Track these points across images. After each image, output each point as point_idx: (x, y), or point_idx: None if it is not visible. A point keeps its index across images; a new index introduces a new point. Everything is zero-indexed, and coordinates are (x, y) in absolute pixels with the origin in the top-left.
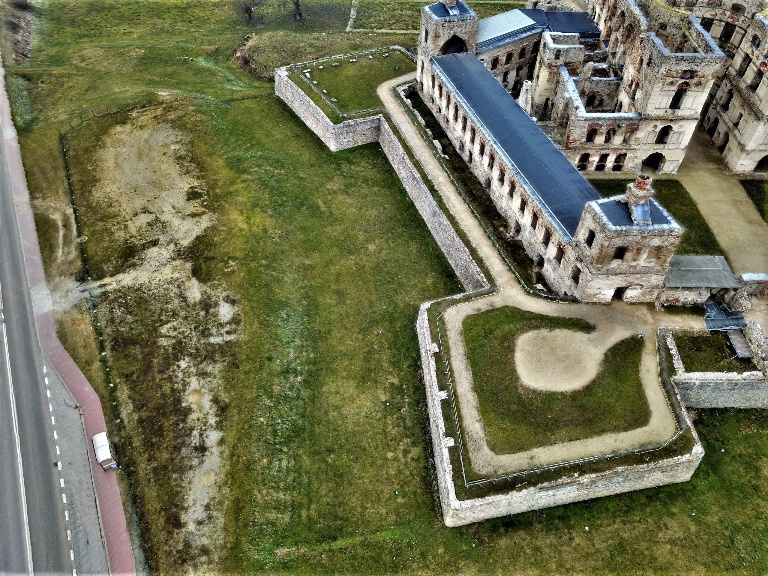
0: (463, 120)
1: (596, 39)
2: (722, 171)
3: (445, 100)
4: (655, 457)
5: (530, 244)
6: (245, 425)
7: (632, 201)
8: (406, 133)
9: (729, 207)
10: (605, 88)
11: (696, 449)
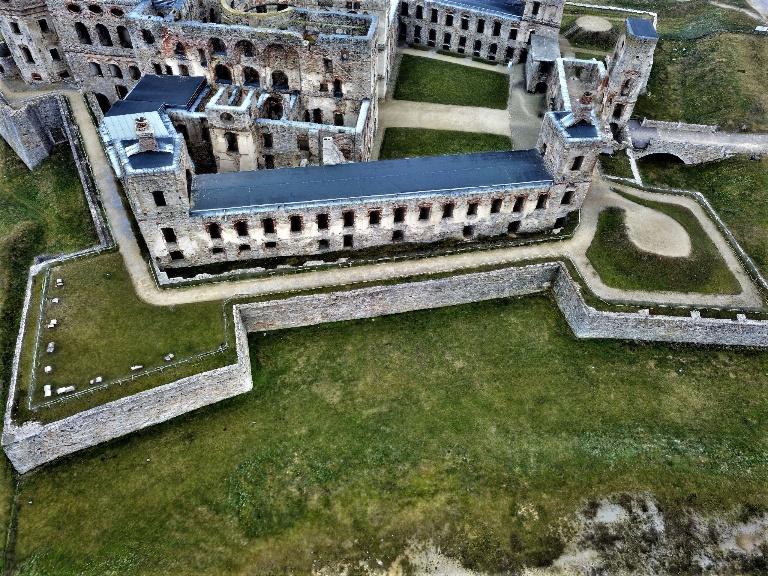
0: (317, 219)
1: (207, 86)
2: (380, 103)
3: (261, 228)
4: (712, 214)
5: (495, 226)
6: (765, 485)
7: (589, 114)
8: (287, 286)
9: (428, 114)
10: (296, 109)
11: (700, 194)
